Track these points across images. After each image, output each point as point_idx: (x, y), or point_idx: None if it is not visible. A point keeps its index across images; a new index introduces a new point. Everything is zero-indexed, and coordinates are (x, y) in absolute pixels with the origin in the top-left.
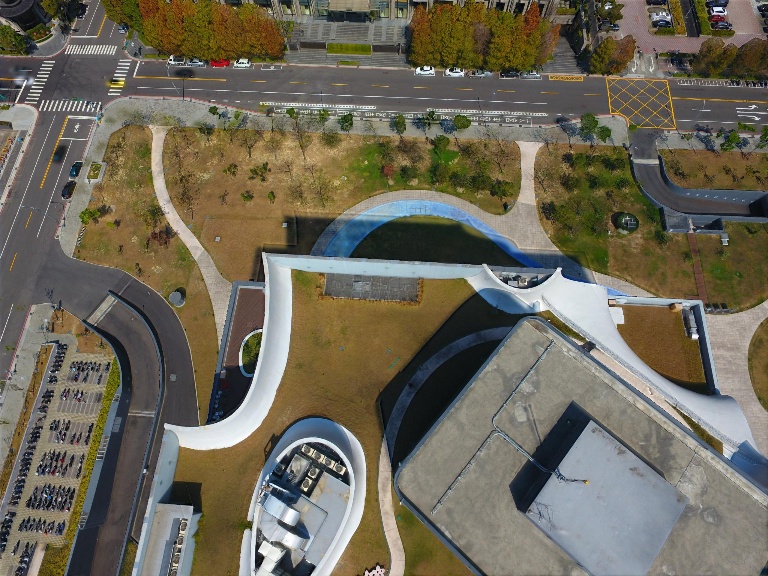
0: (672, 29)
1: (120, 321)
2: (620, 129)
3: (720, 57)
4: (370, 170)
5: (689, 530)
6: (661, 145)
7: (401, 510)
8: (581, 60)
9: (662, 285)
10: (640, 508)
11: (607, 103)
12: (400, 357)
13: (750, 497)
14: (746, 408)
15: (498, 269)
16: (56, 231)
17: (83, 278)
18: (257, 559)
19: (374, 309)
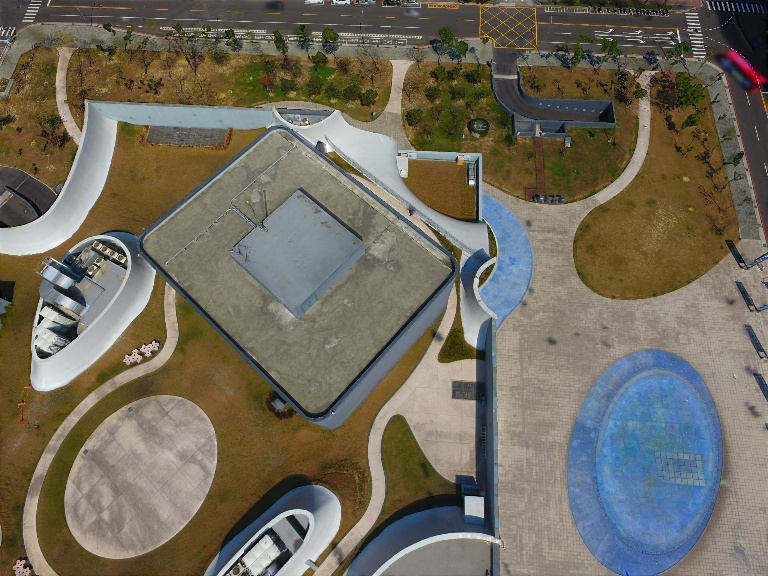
0: None
1: (14, 212)
2: (486, 49)
3: None
4: (254, 84)
5: (372, 275)
6: (522, 63)
7: (182, 302)
8: None
9: (506, 180)
10: (321, 248)
11: (478, 27)
12: None
13: (428, 253)
14: (566, 281)
15: (285, 111)
16: None
17: None
18: (40, 322)
19: (187, 153)
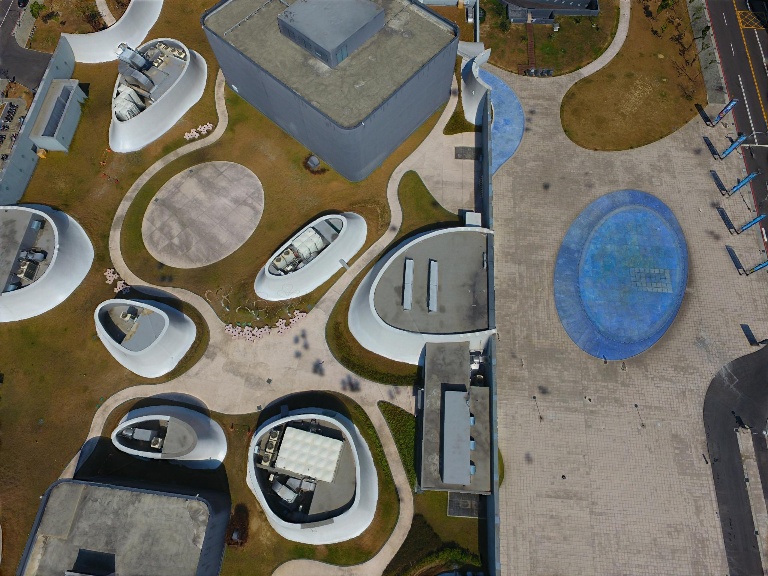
0: None
1: None
2: None
3: None
4: None
5: (391, 41)
6: None
7: (230, 97)
8: None
9: (501, 58)
10: (351, 13)
11: None
12: None
13: (436, 26)
14: (554, 137)
15: None
16: (12, 30)
17: (33, 62)
18: None
19: None
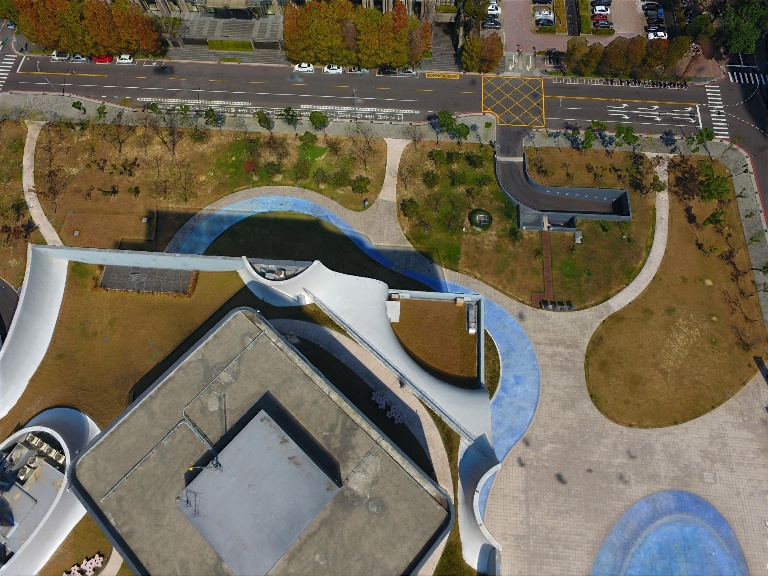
0: (553, 28)
1: None
2: None
3: (588, 55)
4: (237, 166)
5: (351, 519)
6: (527, 143)
7: None
8: (459, 58)
9: (510, 282)
10: (287, 496)
11: (480, 101)
12: (162, 348)
13: (419, 487)
14: (577, 405)
15: (257, 261)
16: None
17: None
18: None
19: (146, 301)
